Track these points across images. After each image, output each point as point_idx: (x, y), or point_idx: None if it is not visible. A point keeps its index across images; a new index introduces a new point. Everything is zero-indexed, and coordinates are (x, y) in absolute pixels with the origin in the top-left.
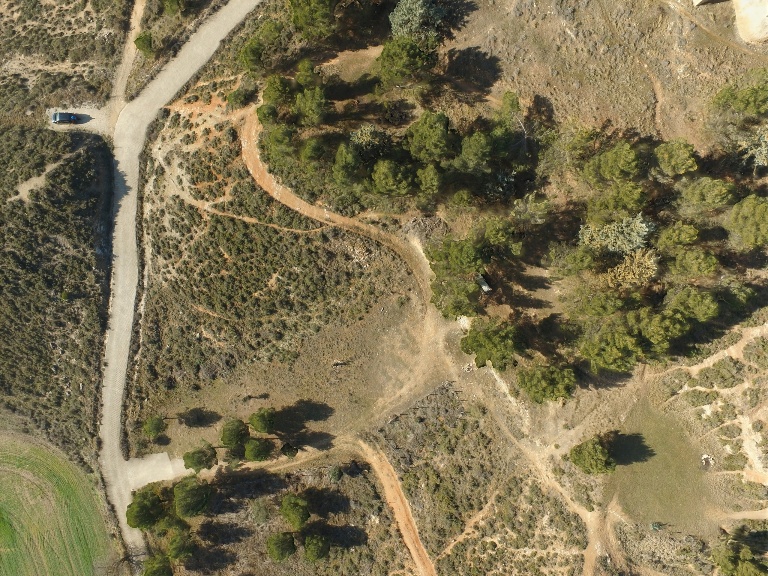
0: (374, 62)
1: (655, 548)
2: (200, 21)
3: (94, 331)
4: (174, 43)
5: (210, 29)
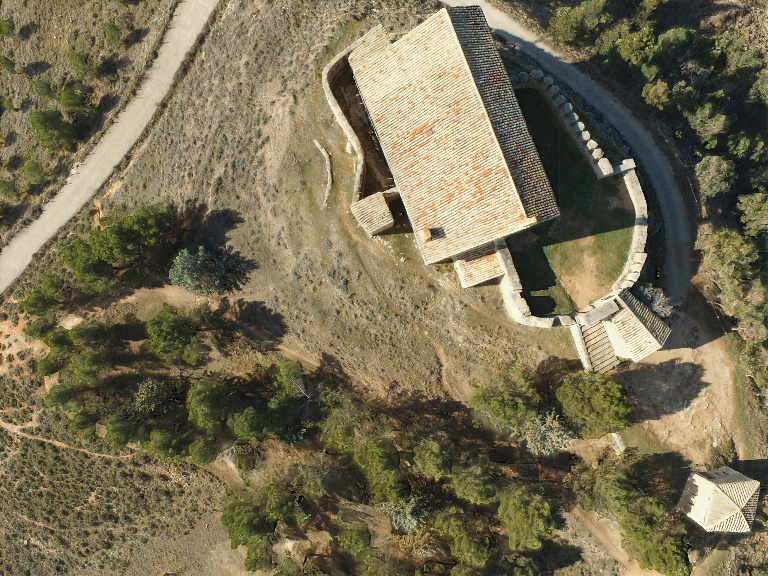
0: (169, 302)
1: None
2: (12, 234)
3: None
4: None
5: (22, 242)
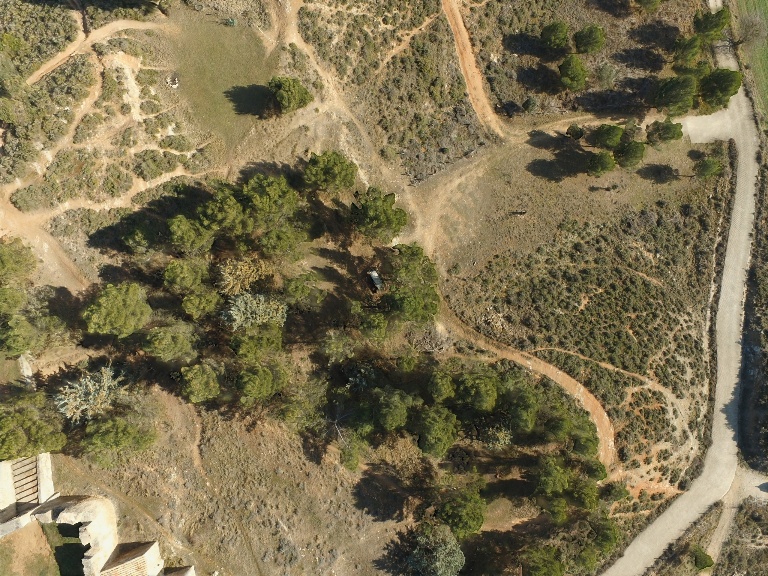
0: None
1: (232, 2)
2: None
3: (762, 269)
4: (671, 558)
5: (633, 570)
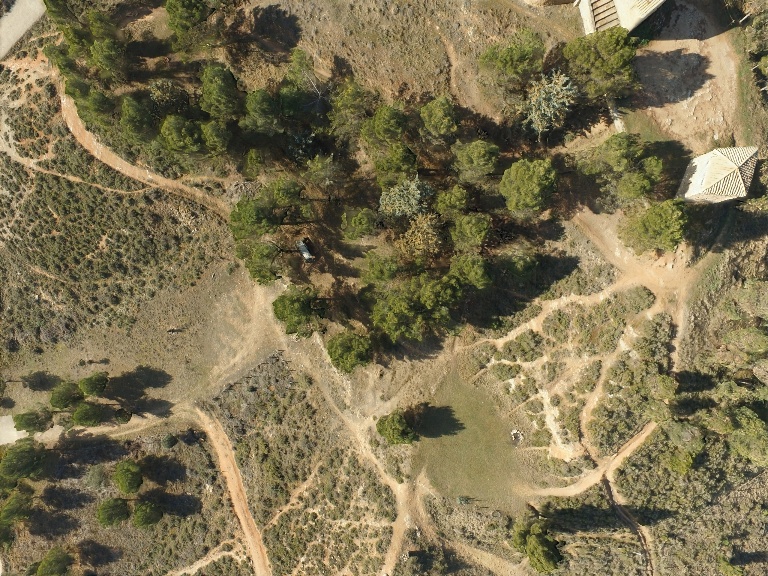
0: None
1: (464, 523)
2: None
3: None
4: None
5: None
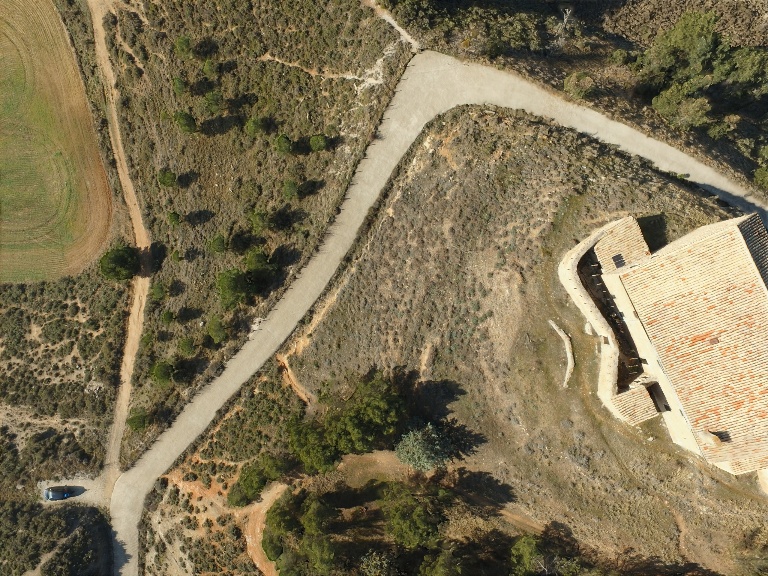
0: (380, 467)
1: None
2: (194, 392)
3: None
4: (168, 414)
5: (205, 399)
